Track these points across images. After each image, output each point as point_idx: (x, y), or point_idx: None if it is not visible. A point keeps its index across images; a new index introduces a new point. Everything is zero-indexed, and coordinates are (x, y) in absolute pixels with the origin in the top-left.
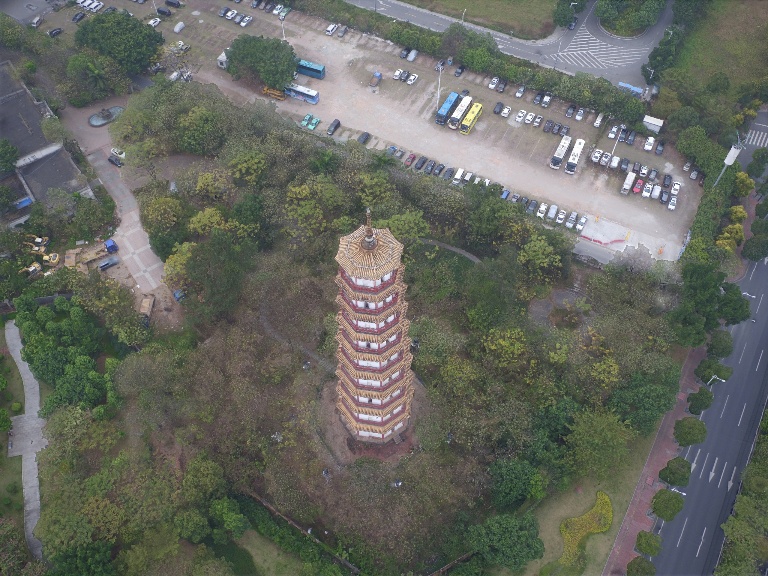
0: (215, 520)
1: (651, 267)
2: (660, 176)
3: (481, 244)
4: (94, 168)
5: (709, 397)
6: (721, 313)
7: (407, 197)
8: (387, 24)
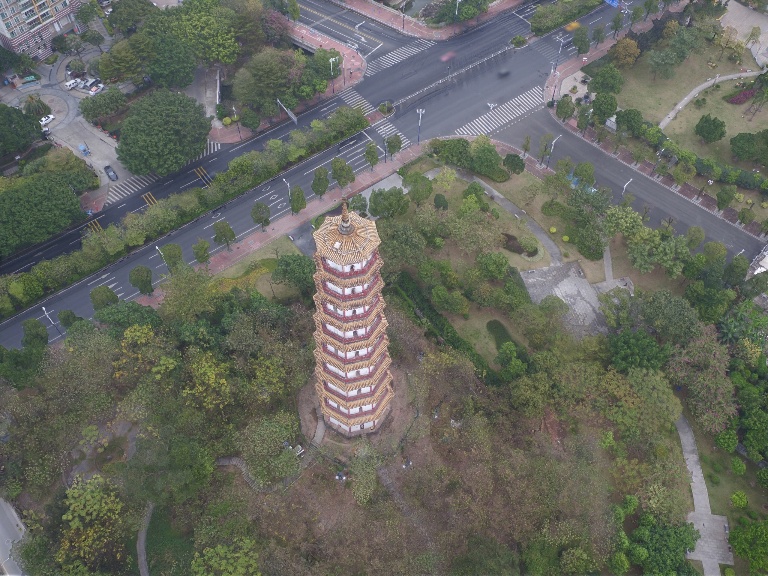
0: None
1: None
2: None
3: None
4: None
5: None
6: None
7: None
8: None
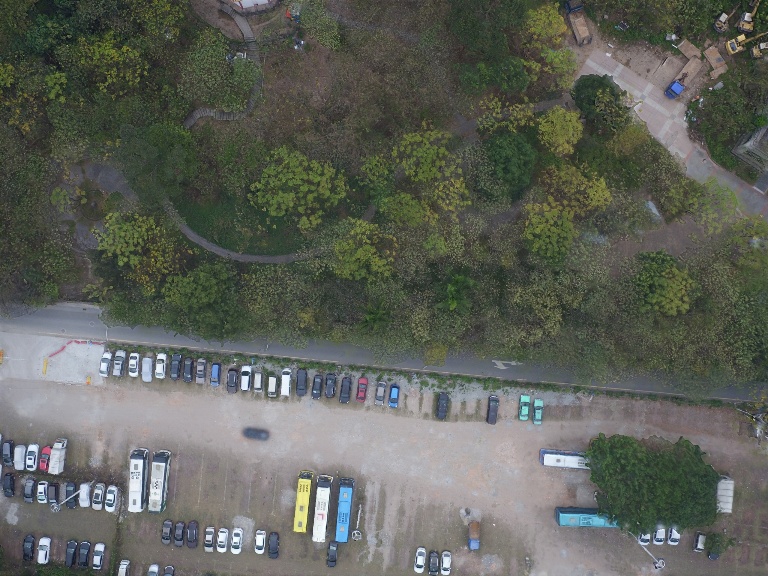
0: None
1: None
2: (21, 493)
3: None
4: None
5: None
6: None
7: None
8: None
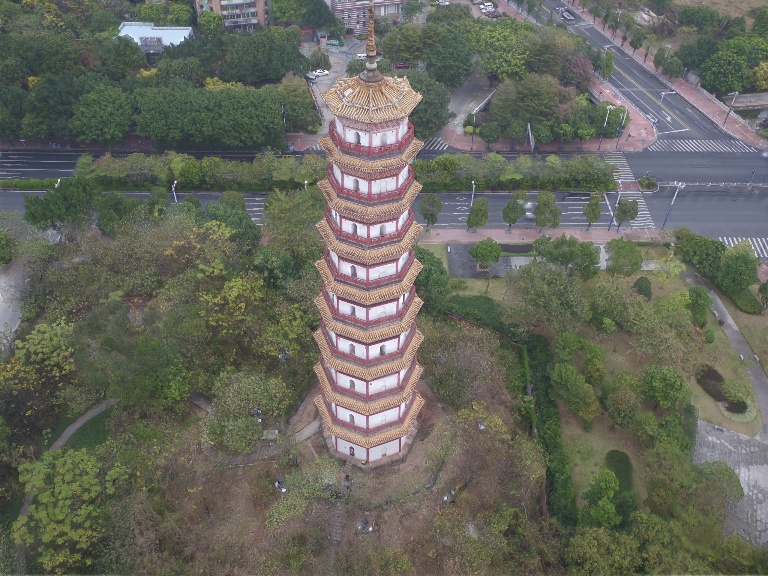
0: None
1: (35, 256)
2: None
3: None
4: None
5: None
6: (95, 188)
7: None
8: None
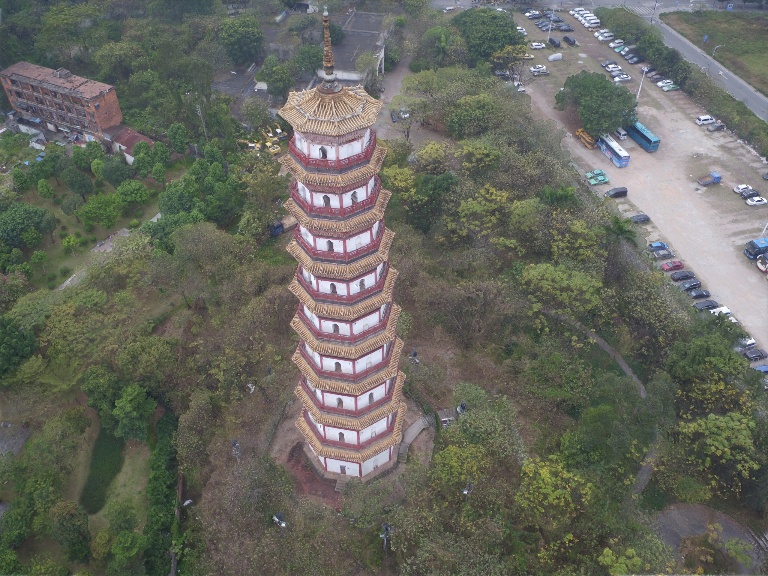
0: None
1: None
2: None
3: None
4: None
5: None
6: None
7: (619, 283)
8: None
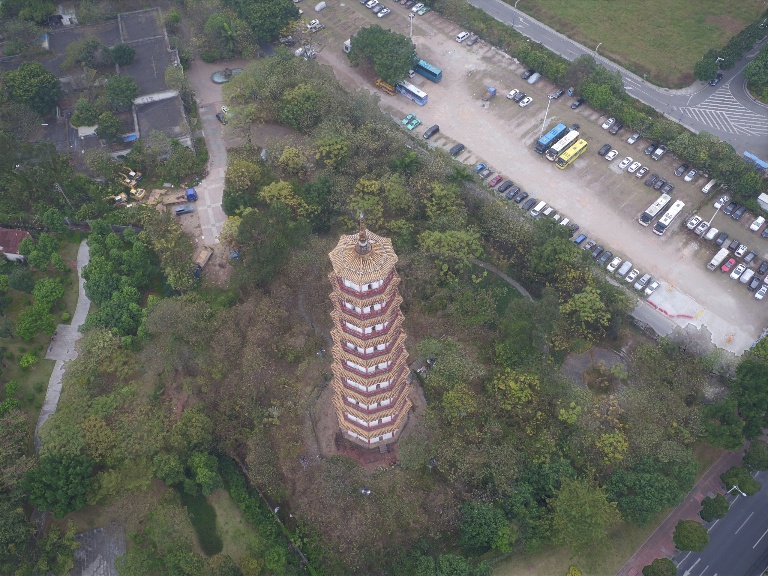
0: (192, 470)
1: (707, 352)
2: (758, 260)
3: (537, 282)
4: (202, 120)
5: (724, 507)
6: (766, 422)
7: (476, 216)
8: (517, 42)
